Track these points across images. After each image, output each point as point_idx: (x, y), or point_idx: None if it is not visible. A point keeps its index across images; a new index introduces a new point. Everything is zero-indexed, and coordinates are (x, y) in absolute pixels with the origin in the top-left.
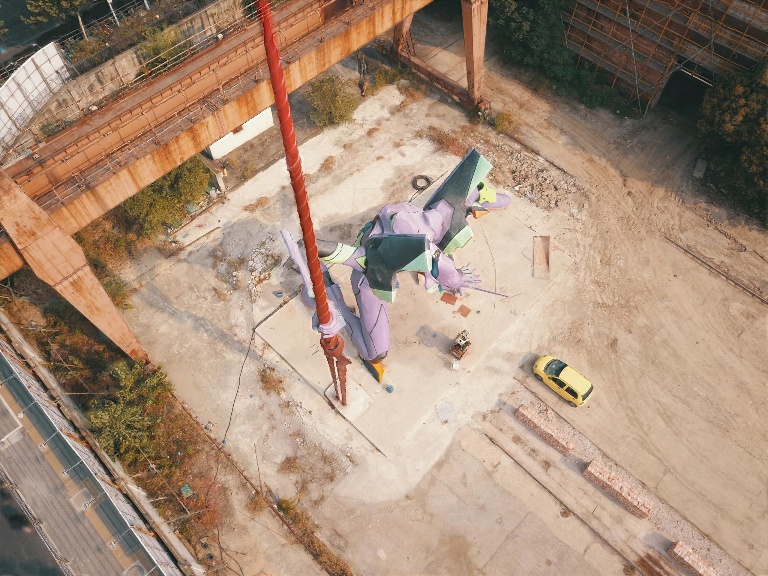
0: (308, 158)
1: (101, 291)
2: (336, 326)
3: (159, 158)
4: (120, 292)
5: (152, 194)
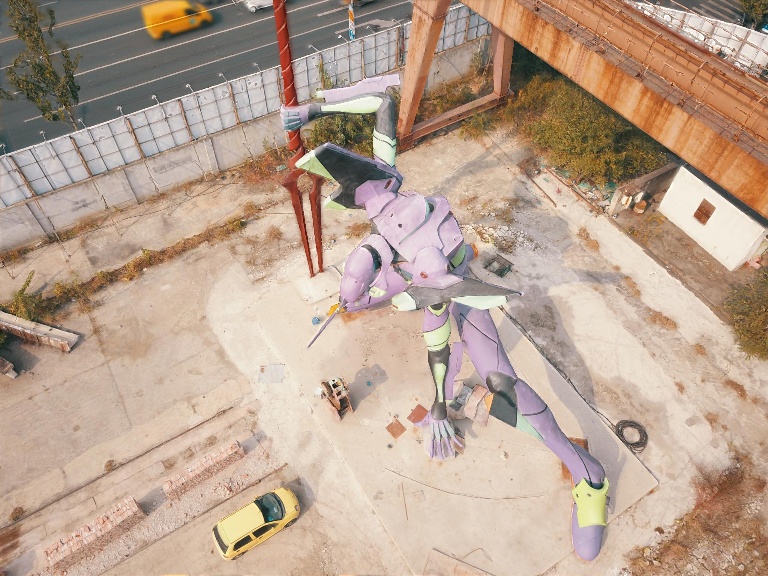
0: (671, 300)
1: (424, 50)
2: (282, 116)
3: (526, 22)
4: (479, 131)
5: (567, 116)
